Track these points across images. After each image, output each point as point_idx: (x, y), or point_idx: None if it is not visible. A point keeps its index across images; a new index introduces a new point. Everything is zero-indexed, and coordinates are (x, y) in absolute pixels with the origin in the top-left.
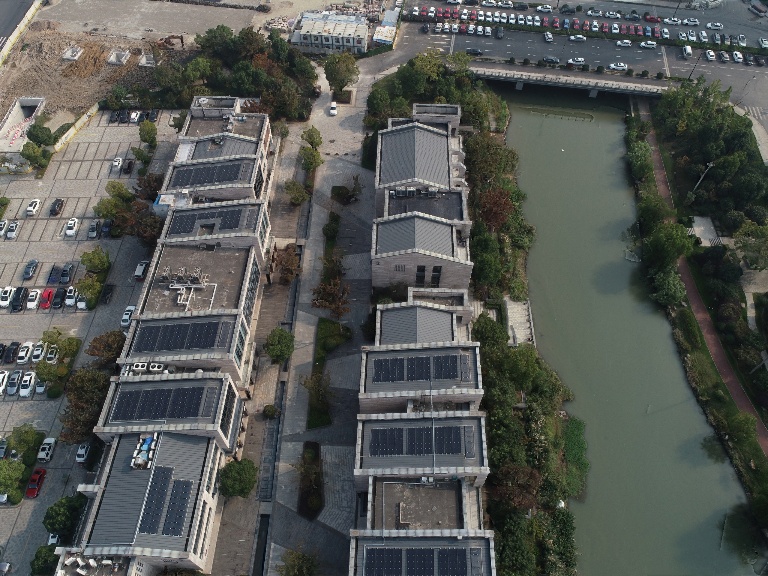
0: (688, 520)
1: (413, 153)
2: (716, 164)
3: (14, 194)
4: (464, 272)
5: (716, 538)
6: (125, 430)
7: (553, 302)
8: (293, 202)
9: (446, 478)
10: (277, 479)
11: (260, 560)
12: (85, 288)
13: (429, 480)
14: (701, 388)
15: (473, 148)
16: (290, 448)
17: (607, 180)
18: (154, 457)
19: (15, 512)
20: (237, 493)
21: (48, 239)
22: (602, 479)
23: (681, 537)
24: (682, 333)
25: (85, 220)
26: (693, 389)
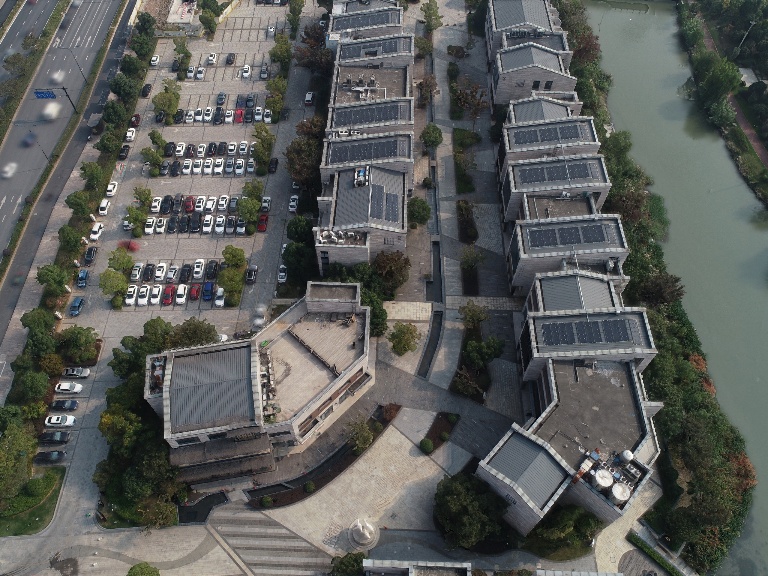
0: (746, 253)
1: (521, 8)
2: (756, 27)
3: (193, 51)
4: (569, 87)
5: (767, 264)
6: (344, 166)
7: (630, 126)
8: (419, 55)
9: (579, 194)
10: (440, 222)
11: (437, 267)
12: (274, 103)
13: (567, 195)
14: (751, 176)
15: (563, 12)
16: (446, 205)
17: (665, 48)
18: (370, 179)
19: (251, 240)
20: (419, 220)
21: (229, 80)
22: (680, 229)
23: (741, 262)
24: (734, 143)
25: (255, 68)
26: (744, 178)
